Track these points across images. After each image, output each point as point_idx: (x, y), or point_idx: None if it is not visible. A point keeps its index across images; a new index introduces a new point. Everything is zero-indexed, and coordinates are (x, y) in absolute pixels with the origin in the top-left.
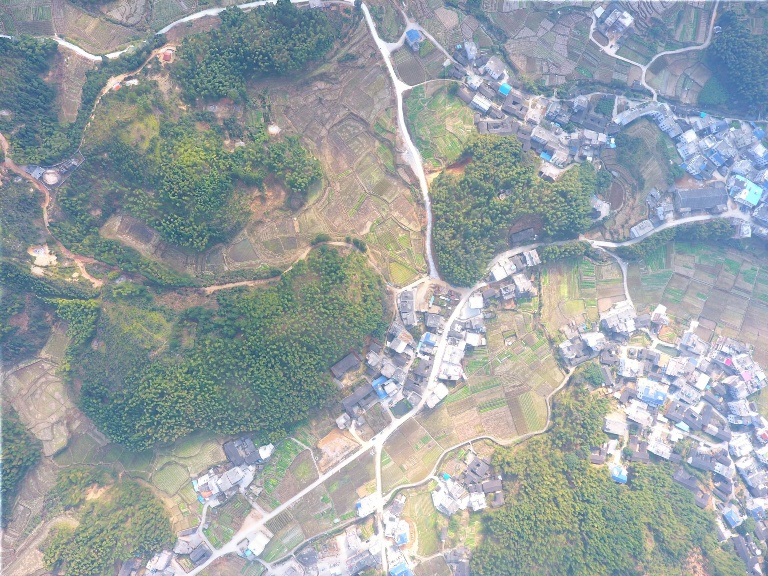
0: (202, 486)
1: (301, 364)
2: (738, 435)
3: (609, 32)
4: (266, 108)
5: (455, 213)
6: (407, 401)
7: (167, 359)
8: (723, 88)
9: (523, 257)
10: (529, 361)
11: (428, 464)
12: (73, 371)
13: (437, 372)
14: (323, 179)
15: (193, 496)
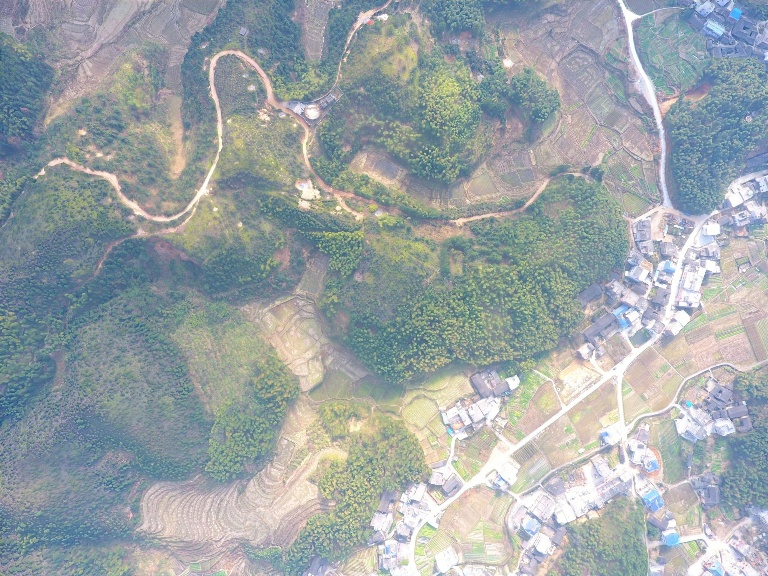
0: (453, 418)
1: (561, 290)
2: None
3: None
4: (500, 42)
5: (703, 136)
6: (645, 330)
7: (439, 286)
8: None
9: (756, 183)
10: (764, 287)
11: (669, 392)
12: (341, 303)
13: (674, 301)
14: (556, 111)
15: (442, 429)
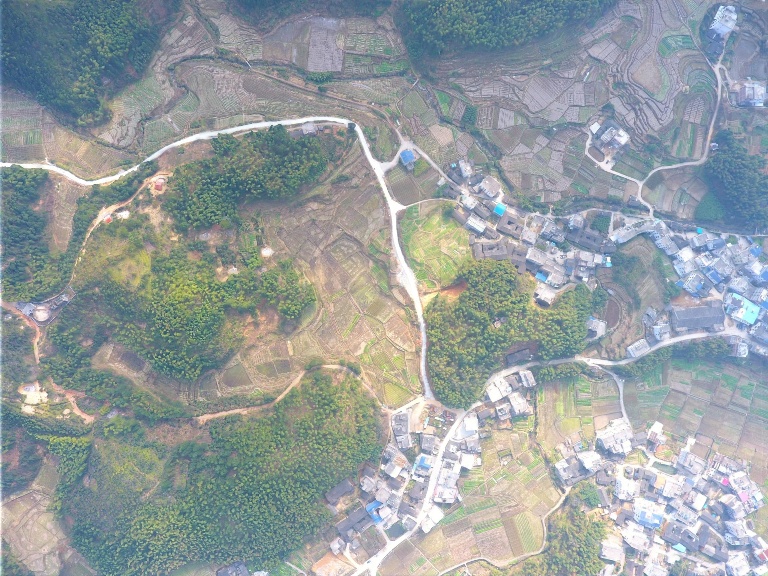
0: None
1: (295, 498)
2: (735, 554)
3: (605, 148)
4: (259, 231)
5: (450, 342)
6: (402, 523)
7: (159, 500)
8: (720, 204)
9: (519, 377)
10: (525, 481)
11: None
12: (64, 509)
13: (432, 493)
14: (317, 301)
15: None
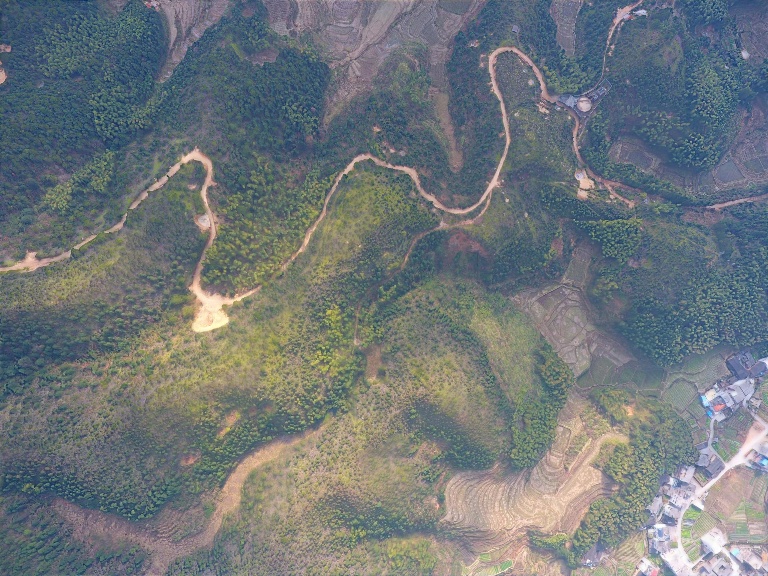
0: (714, 400)
1: None
2: None
3: None
4: (736, 35)
5: None
6: None
7: (721, 269)
8: None
9: None
10: None
11: None
12: (620, 289)
13: None
14: None
15: (701, 411)
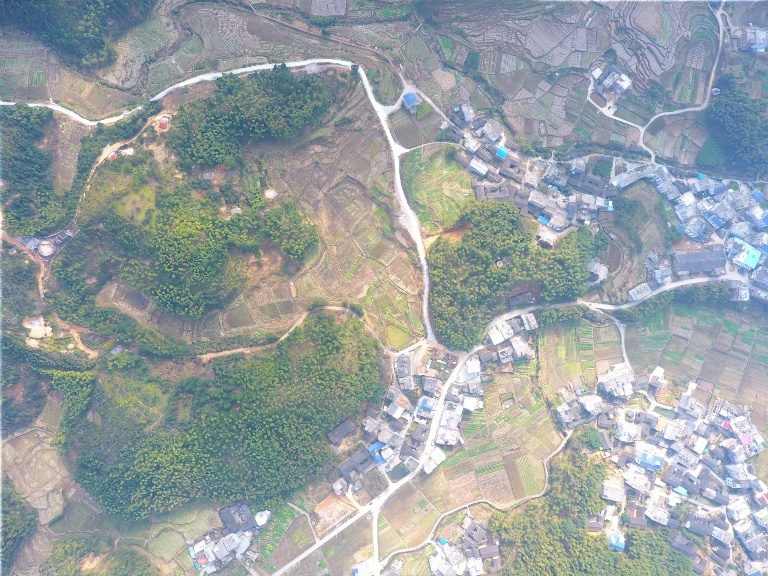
0: (198, 553)
1: (297, 435)
2: (736, 498)
3: (607, 93)
4: (263, 172)
5: (452, 281)
6: (404, 465)
7: (163, 433)
8: (721, 149)
9: (521, 320)
10: (526, 424)
11: (425, 528)
12: (68, 443)
13: (434, 436)
14: (320, 243)
15: (189, 562)
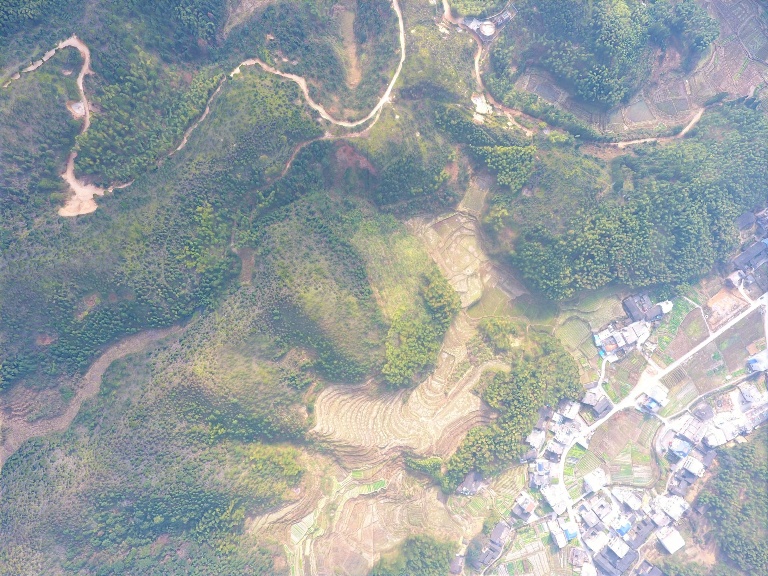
0: (606, 340)
1: (725, 211)
2: None
3: None
4: None
5: None
6: None
7: (611, 200)
8: None
9: None
10: None
11: None
12: (510, 216)
13: None
14: (711, 43)
15: (593, 351)
